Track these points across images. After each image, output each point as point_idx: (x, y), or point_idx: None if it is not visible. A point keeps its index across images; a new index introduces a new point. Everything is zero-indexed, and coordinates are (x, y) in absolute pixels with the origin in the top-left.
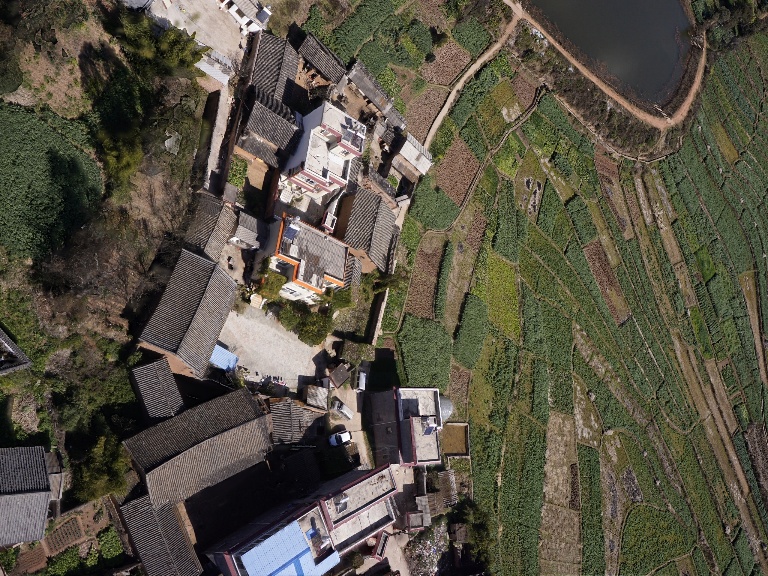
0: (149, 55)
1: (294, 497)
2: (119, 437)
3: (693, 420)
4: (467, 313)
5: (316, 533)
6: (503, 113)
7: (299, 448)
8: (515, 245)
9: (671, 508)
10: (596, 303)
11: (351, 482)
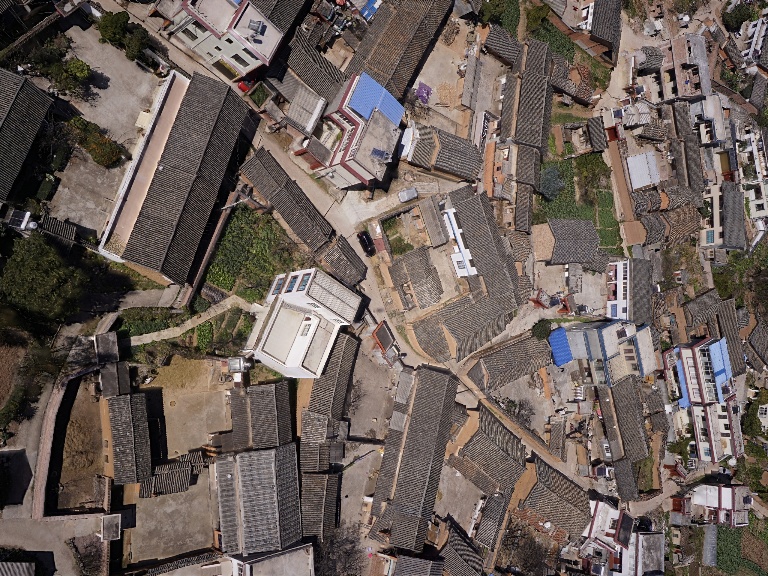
0: None
1: None
2: None
3: None
4: None
5: None
6: None
7: None
8: None
9: None
10: None
11: None
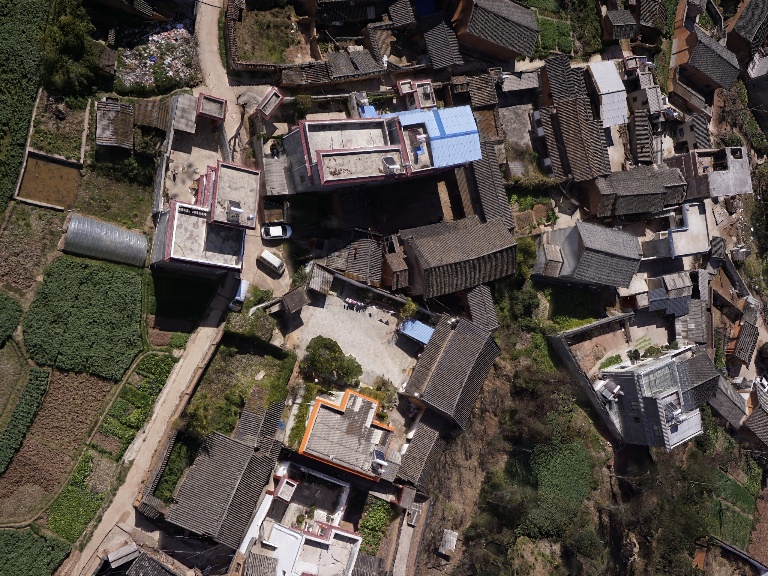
0: None
1: None
2: None
3: None
4: None
5: (415, 149)
6: None
7: None
8: None
9: None
10: None
11: None
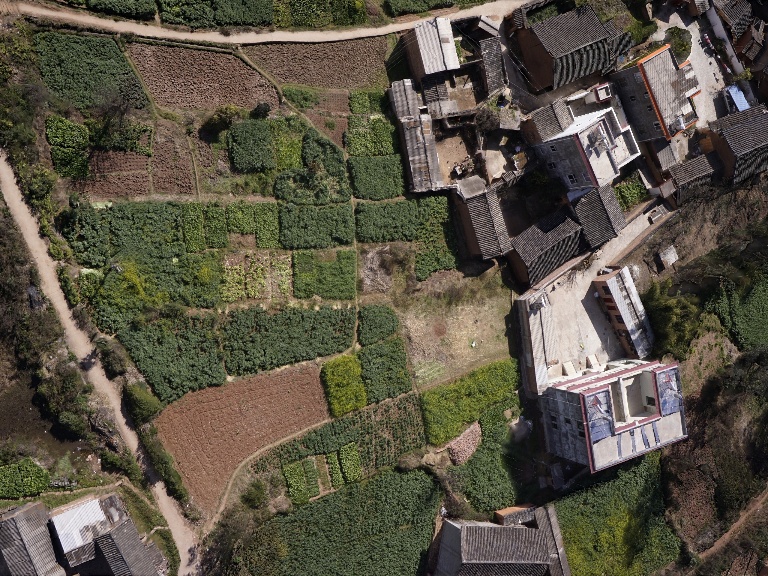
0: None
1: None
2: None
3: None
4: None
5: None
6: None
7: None
8: None
9: None
10: None
11: None
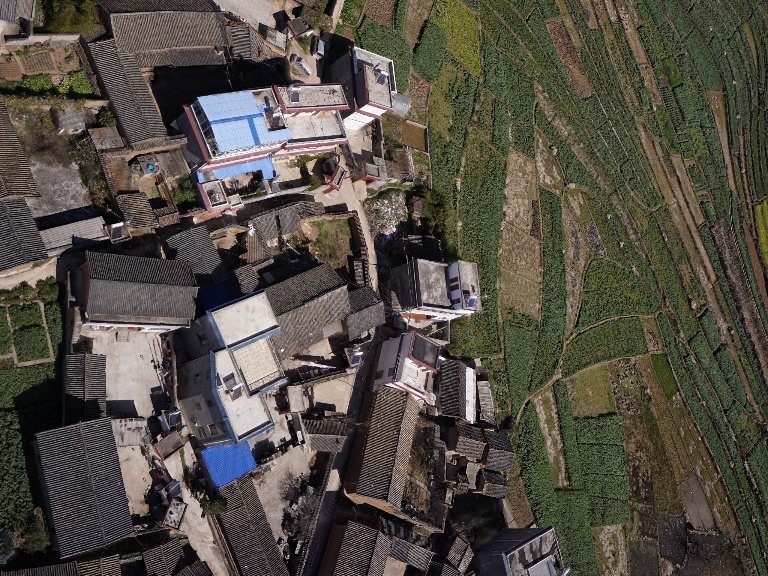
0: None
1: None
2: None
3: (658, 201)
4: (426, 34)
5: (270, 109)
6: None
7: (257, 64)
8: None
9: (635, 270)
10: (558, 72)
11: (304, 84)
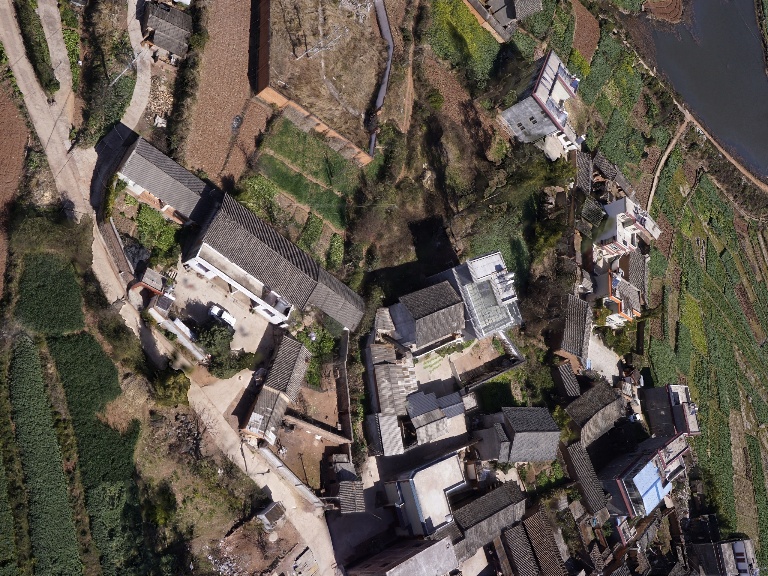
0: (546, 174)
1: (625, 452)
2: (560, 407)
3: None
4: (681, 336)
5: (659, 470)
6: (681, 190)
7: None
8: (698, 287)
9: None
10: (746, 330)
11: (668, 441)
